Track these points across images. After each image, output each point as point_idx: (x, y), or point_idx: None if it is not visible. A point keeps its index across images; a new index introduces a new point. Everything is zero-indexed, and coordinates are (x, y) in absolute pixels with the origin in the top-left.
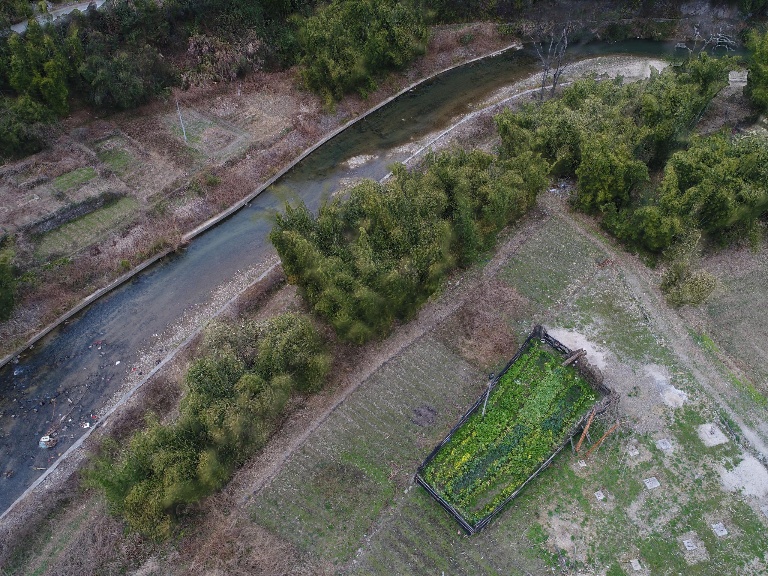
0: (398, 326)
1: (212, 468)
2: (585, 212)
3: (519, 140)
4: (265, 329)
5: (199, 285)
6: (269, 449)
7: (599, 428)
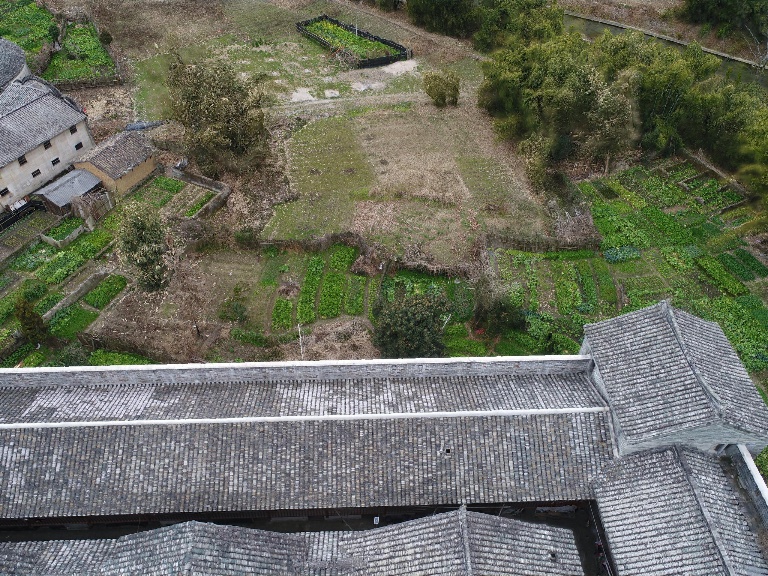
0: None
1: None
2: None
3: None
4: None
5: None
6: (350, 2)
7: None
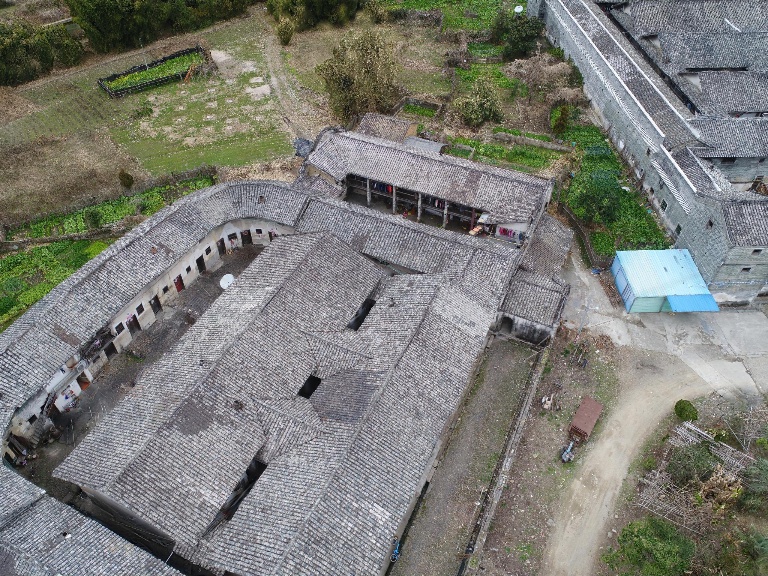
0: (133, 50)
1: None
2: (270, 13)
3: None
4: None
5: None
6: (40, 80)
7: None
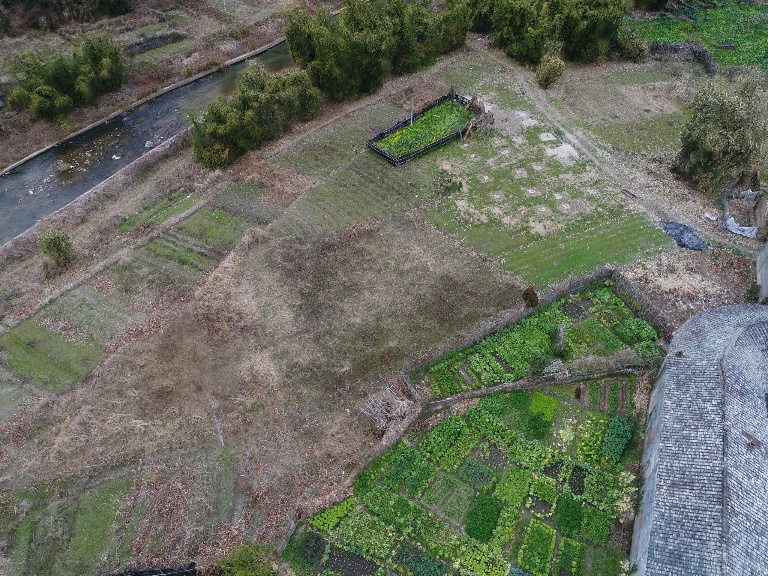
0: (365, 96)
1: (252, 123)
2: (498, 46)
3: (457, 4)
4: None
5: (237, 85)
6: (283, 139)
7: (479, 131)
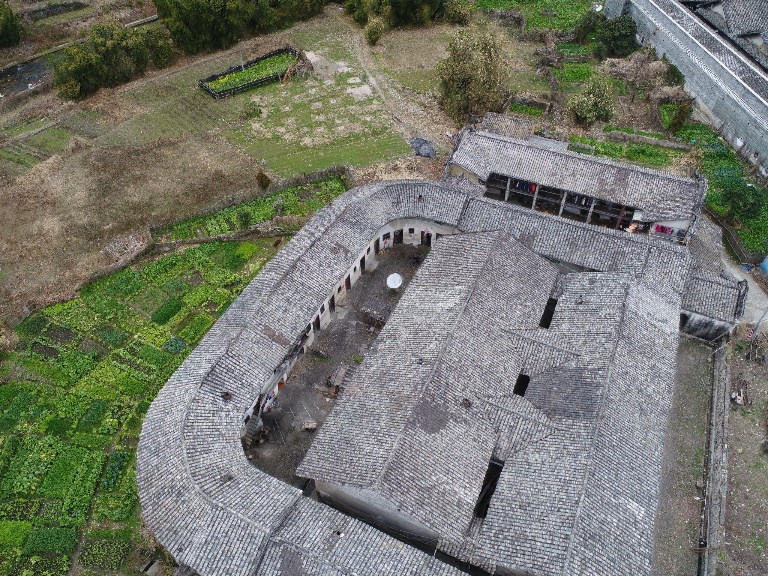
0: (220, 51)
1: (100, 64)
2: (348, 13)
3: None
4: (139, 29)
5: None
6: (136, 81)
7: None
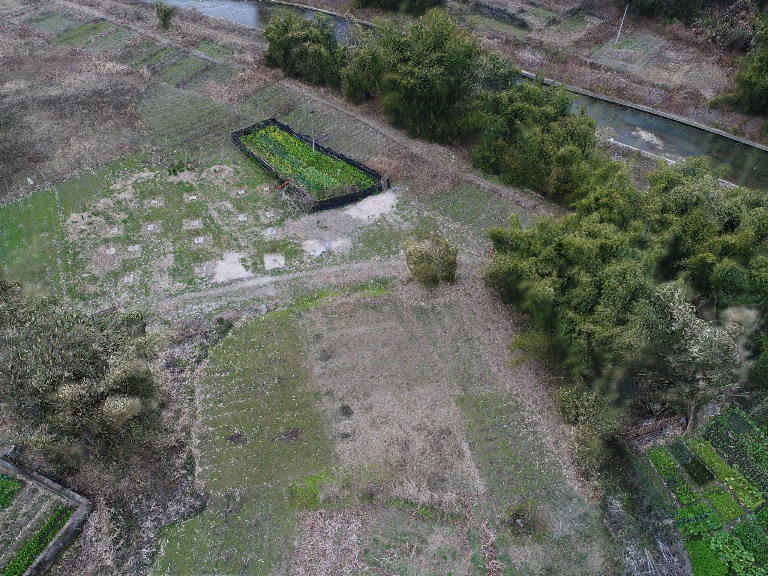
0: (405, 132)
1: (279, 45)
2: None
3: None
4: (367, 48)
5: None
6: (309, 88)
7: None
